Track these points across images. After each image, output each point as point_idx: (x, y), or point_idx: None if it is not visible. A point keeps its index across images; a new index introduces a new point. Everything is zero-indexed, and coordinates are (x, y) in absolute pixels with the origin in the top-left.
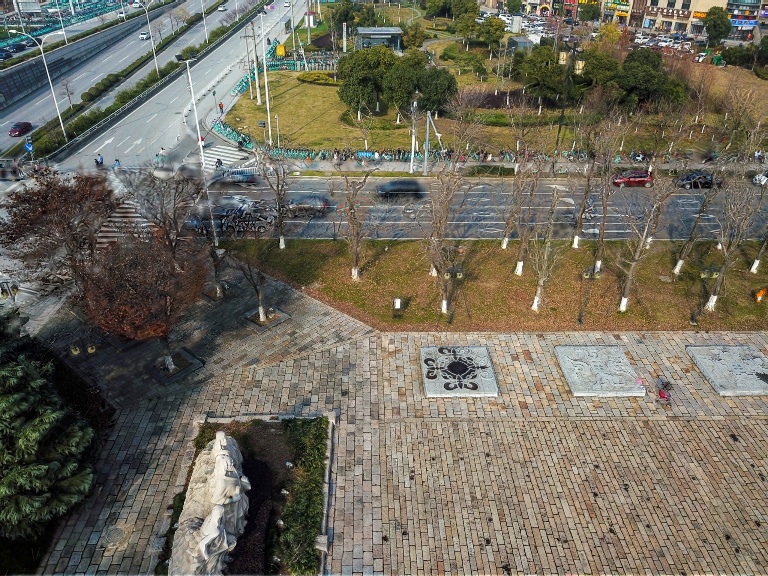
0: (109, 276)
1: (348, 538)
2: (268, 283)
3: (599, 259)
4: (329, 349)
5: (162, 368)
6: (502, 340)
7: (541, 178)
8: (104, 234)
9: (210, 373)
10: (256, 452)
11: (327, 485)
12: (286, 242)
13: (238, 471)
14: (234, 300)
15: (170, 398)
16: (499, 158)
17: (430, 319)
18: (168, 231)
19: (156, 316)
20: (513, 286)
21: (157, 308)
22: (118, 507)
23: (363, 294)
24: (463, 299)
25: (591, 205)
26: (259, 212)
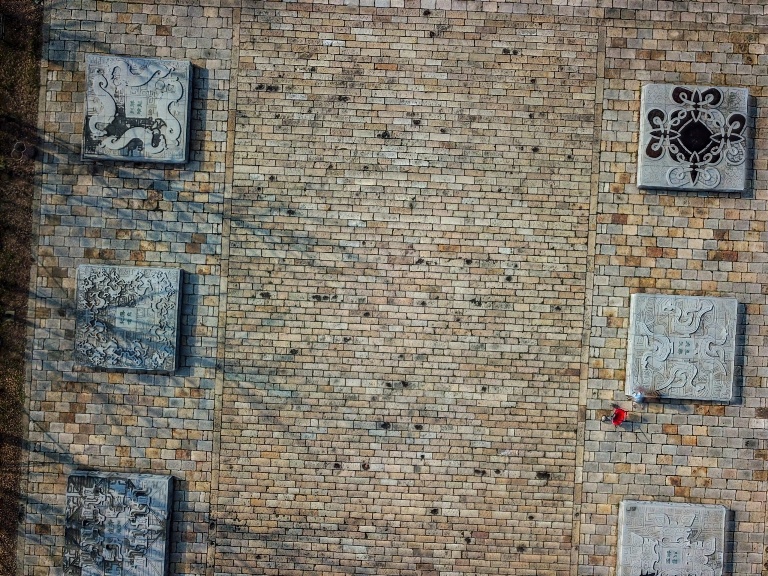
0: None
1: None
2: None
3: None
4: None
5: None
6: (765, 226)
7: None
8: None
9: None
10: None
11: None
12: None
13: None
14: None
15: None
16: None
17: None
18: None
19: None
20: None
21: None
22: None
23: None
24: None
25: None
26: None
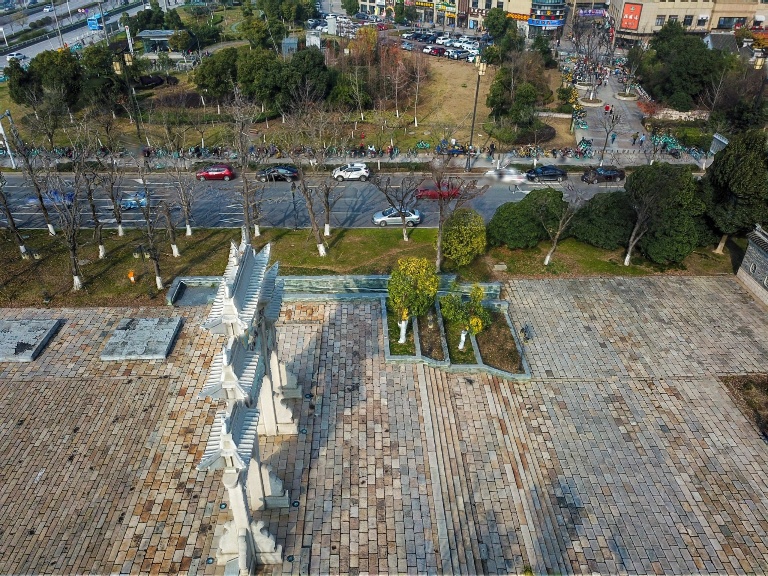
0: None
1: None
2: None
3: (21, 244)
4: None
5: None
6: None
7: (134, 173)
8: None
9: None
10: None
11: None
12: None
13: None
14: None
15: None
16: (119, 154)
17: None
18: None
19: None
20: None
21: None
22: None
23: None
24: None
25: None
26: None
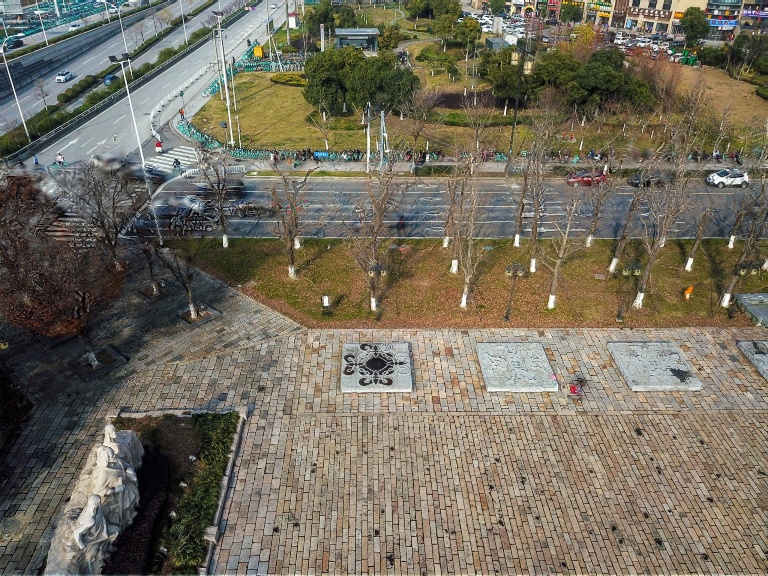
0: (16, 273)
1: (240, 529)
2: (206, 281)
3: (533, 257)
4: (254, 346)
5: (85, 364)
6: (427, 337)
7: (496, 178)
8: (53, 233)
9: (132, 369)
10: (162, 446)
11: (227, 478)
12: (230, 241)
13: (125, 463)
14: (169, 298)
15: (89, 394)
16: (458, 158)
17: (359, 316)
18: (107, 230)
19: (65, 312)
20: (446, 284)
21: (65, 304)
22: (19, 499)
23: (297, 292)
24: (395, 297)
25: (542, 204)
26: (209, 211)
